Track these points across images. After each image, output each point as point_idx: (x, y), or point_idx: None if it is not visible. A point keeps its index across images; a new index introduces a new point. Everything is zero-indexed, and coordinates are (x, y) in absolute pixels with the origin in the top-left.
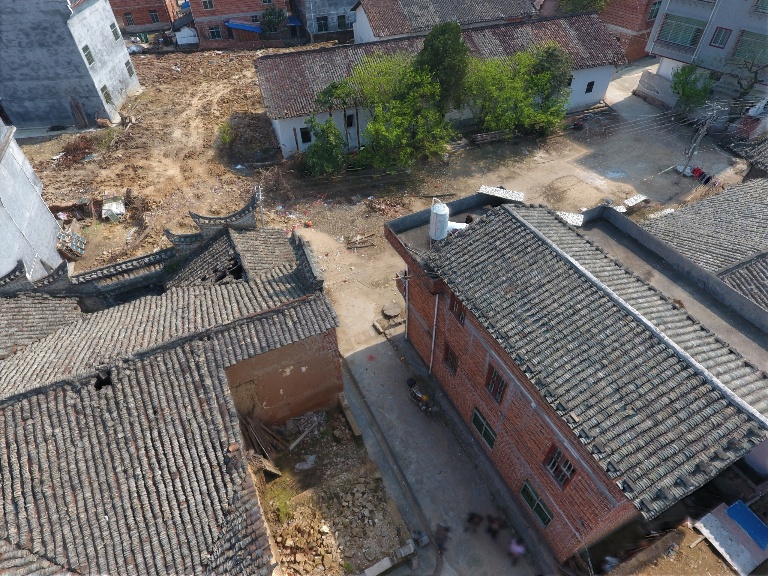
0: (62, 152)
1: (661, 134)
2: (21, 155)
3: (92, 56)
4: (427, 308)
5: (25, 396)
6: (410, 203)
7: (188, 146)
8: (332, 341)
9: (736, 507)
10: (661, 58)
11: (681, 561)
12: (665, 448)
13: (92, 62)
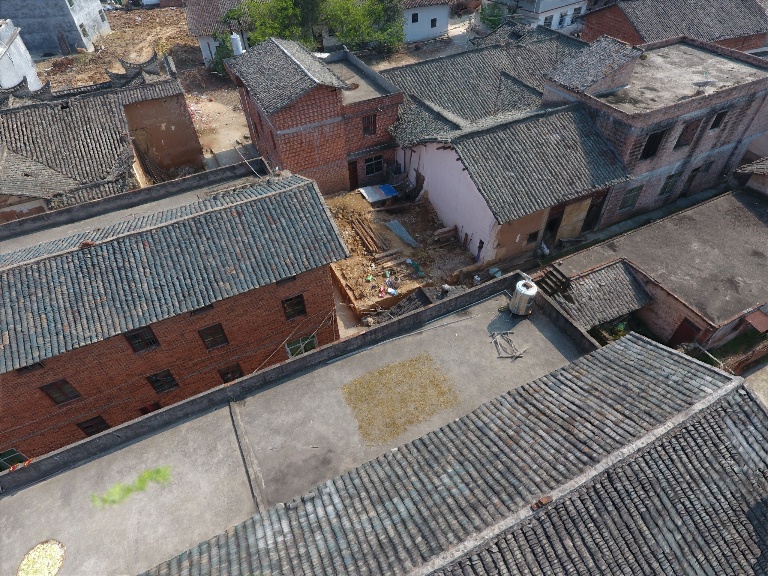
0: (52, 67)
1: None
2: (24, 46)
3: (72, 1)
4: None
5: (29, 108)
6: None
7: None
8: (186, 111)
9: (385, 185)
10: (482, 0)
11: (343, 197)
12: None
13: (72, 5)
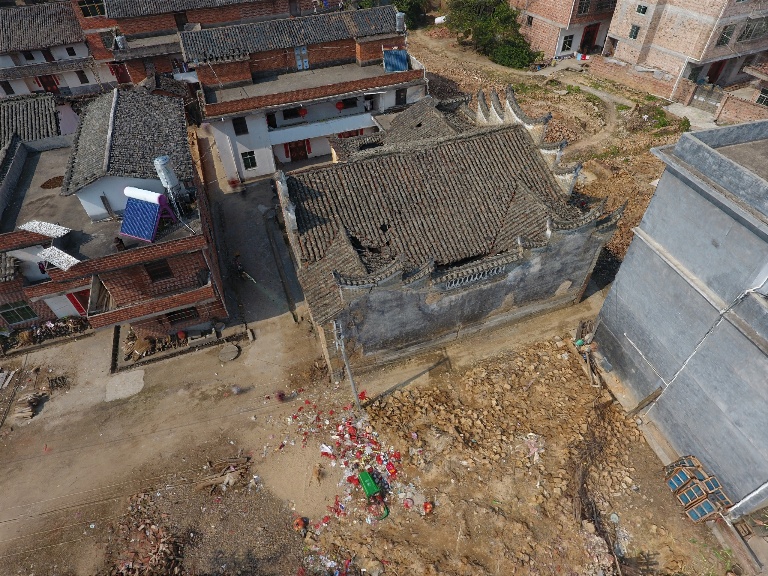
0: None
1: None
2: None
3: None
4: None
5: None
6: (96, 575)
7: None
8: None
9: None
10: None
11: None
12: None
13: None
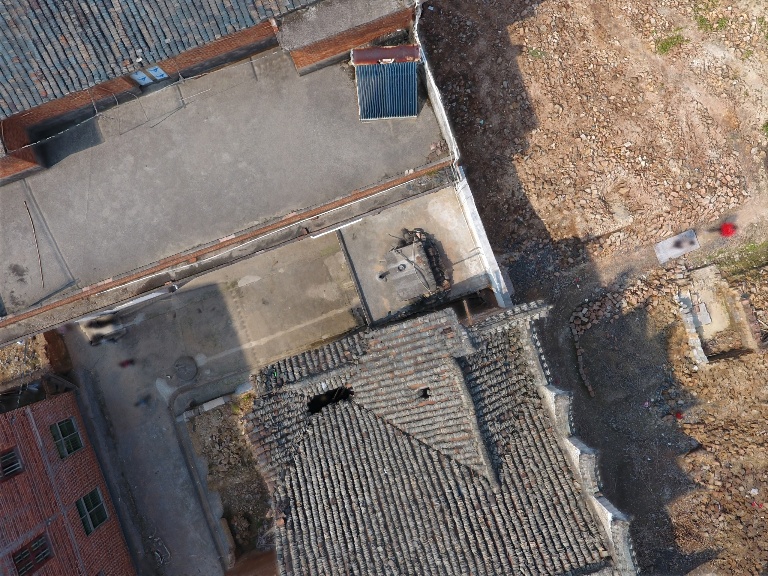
0: None
1: None
2: None
3: None
4: None
5: None
6: None
7: None
8: None
9: None
10: None
11: None
12: None
13: None
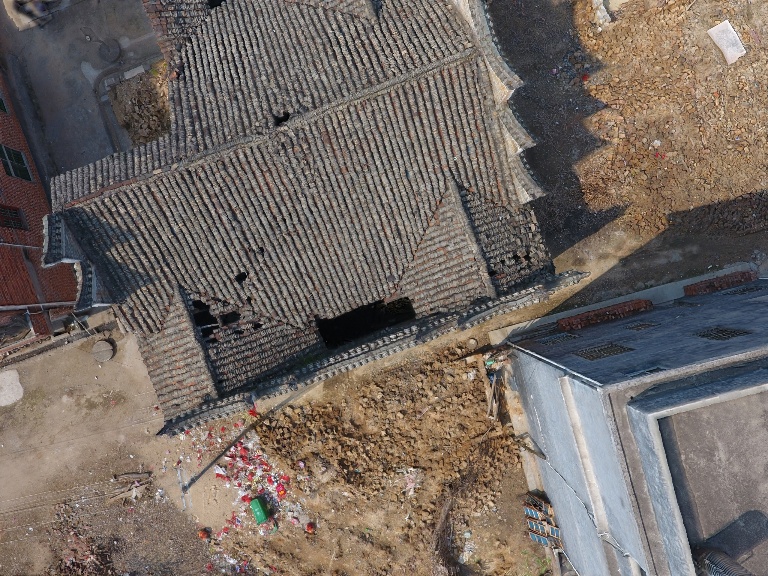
0: None
1: None
2: None
3: None
4: (2, 263)
5: None
6: (49, 568)
7: None
8: None
9: None
10: None
11: None
12: None
13: None
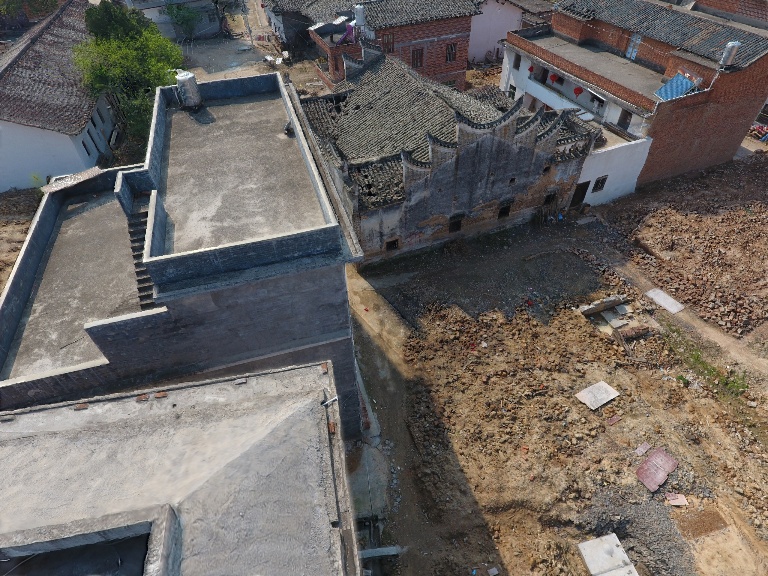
0: None
1: (200, 47)
2: None
3: None
4: None
5: None
6: None
7: (6, 236)
8: None
9: None
10: None
11: None
12: (466, 4)
13: None
